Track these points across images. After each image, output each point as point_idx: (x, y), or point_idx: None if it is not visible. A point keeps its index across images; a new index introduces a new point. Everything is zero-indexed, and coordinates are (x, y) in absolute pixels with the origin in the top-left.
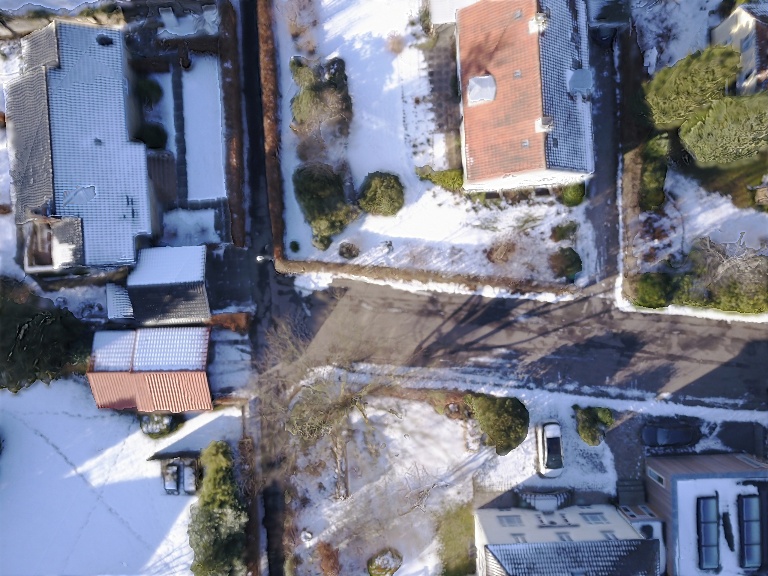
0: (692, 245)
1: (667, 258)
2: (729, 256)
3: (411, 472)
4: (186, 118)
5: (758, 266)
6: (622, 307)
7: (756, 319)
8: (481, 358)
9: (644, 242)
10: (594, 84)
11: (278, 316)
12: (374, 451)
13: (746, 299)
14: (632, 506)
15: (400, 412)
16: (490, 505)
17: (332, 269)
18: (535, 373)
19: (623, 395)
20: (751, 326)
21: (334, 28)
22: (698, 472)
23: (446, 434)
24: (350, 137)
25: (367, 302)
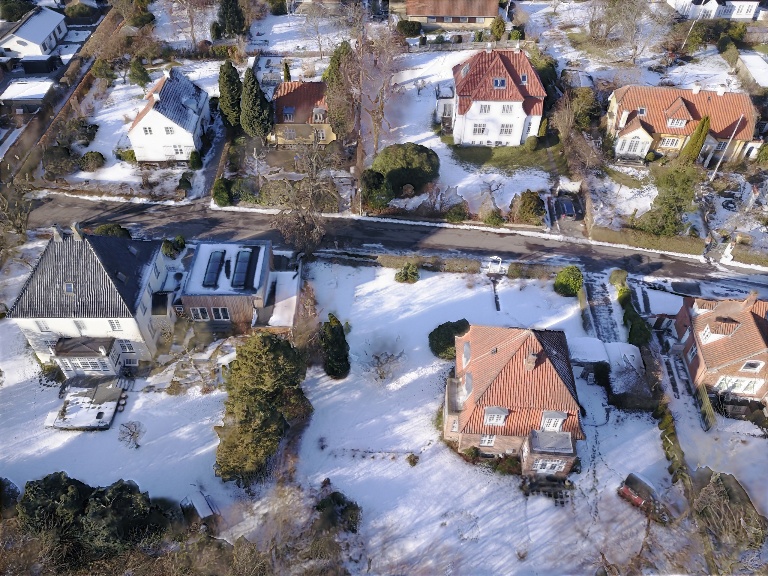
0: None
1: None
2: (256, 162)
3: None
4: (5, 142)
5: None
6: (213, 208)
7: None
8: None
9: None
10: (221, 133)
11: None
12: None
13: (274, 190)
14: None
15: None
16: None
17: (48, 189)
18: (149, 233)
19: None
20: None
21: (100, 118)
22: None
23: None
24: None
25: (62, 204)
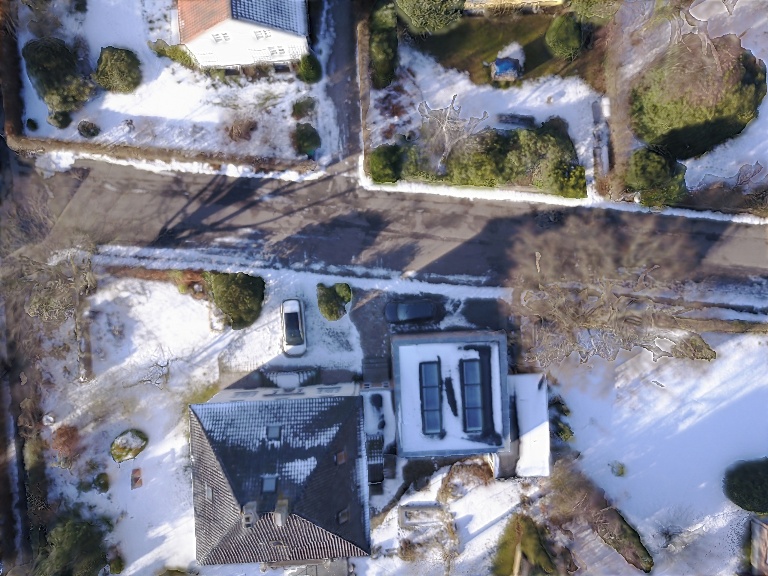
0: (429, 120)
1: (407, 135)
2: (444, 120)
3: (157, 354)
4: None
5: (486, 137)
6: (366, 185)
7: (498, 196)
8: (227, 238)
9: (384, 119)
10: None
11: (20, 198)
12: (117, 333)
13: (475, 170)
14: (375, 382)
15: (144, 293)
16: (236, 385)
17: (72, 149)
18: (281, 253)
19: (369, 274)
20: (493, 203)
21: None
22: (422, 338)
23: (191, 315)
24: (88, 14)
25: (111, 183)
